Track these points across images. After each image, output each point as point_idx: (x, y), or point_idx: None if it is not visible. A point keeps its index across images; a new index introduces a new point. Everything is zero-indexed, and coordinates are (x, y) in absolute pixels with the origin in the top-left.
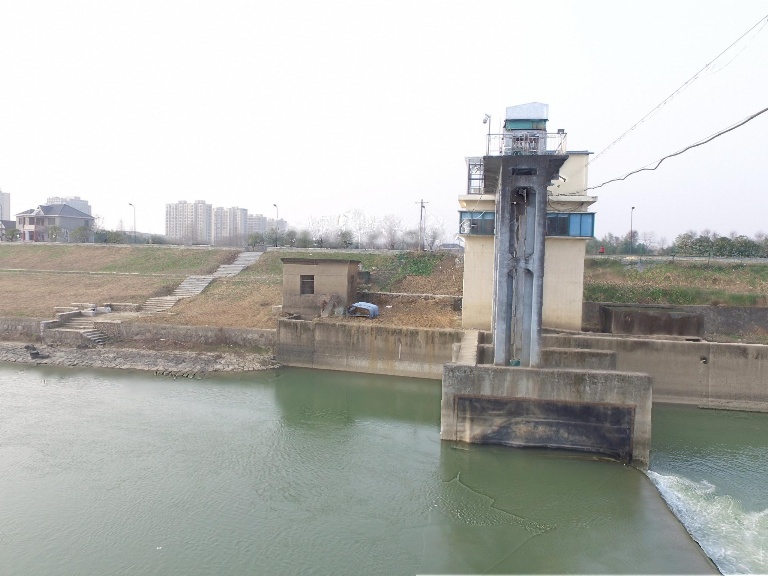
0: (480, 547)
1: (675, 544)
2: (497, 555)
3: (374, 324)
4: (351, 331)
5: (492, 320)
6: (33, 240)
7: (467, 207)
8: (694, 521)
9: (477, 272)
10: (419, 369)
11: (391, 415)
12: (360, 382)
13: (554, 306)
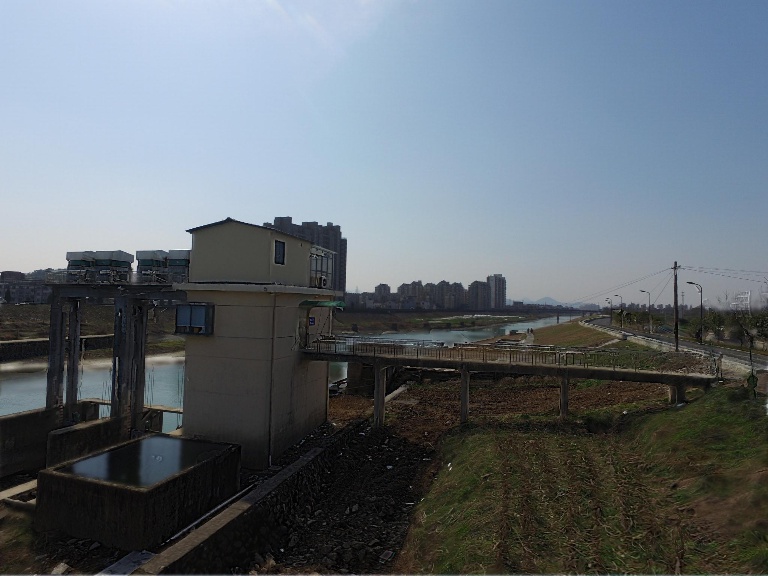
0: None
1: None
2: None
3: None
4: None
5: None
6: None
7: None
8: None
9: None
10: None
11: None
12: None
13: None
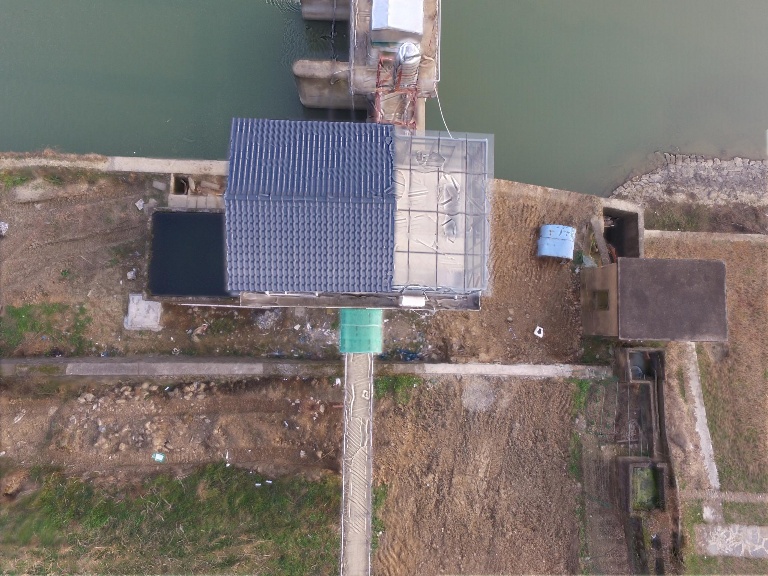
0: None
1: None
2: None
3: (527, 190)
4: None
5: None
6: None
7: None
8: None
9: None
10: None
11: None
12: None
13: None
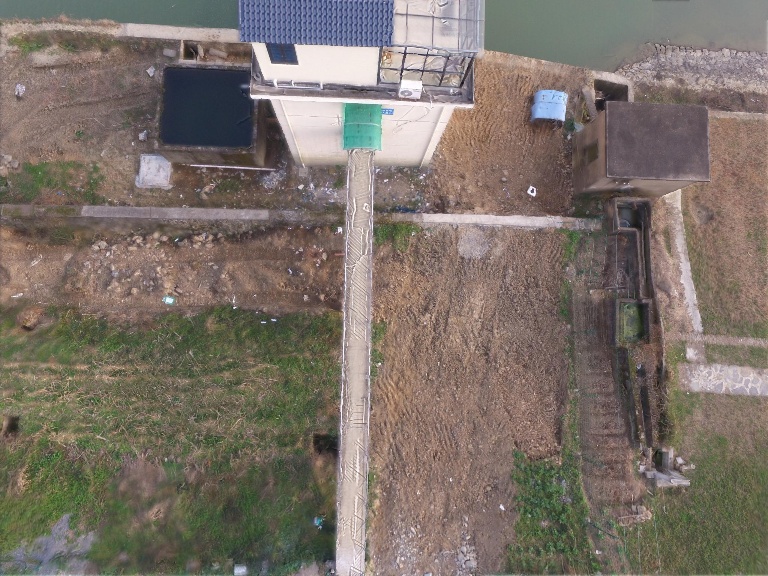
0: None
1: None
2: None
3: (522, 62)
4: None
5: None
6: None
7: None
8: None
9: None
10: None
11: None
12: None
13: None
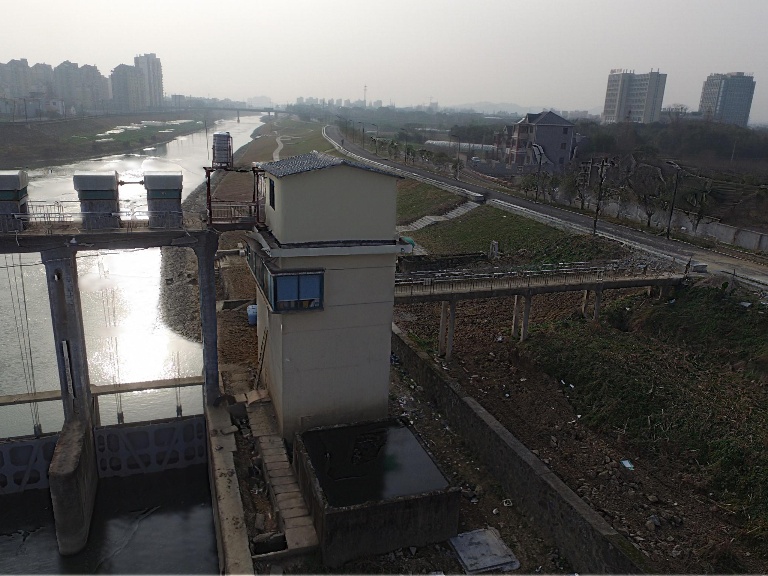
0: None
1: None
2: None
3: None
4: None
5: None
6: (516, 147)
7: None
8: None
9: None
10: None
11: None
12: None
13: (275, 388)
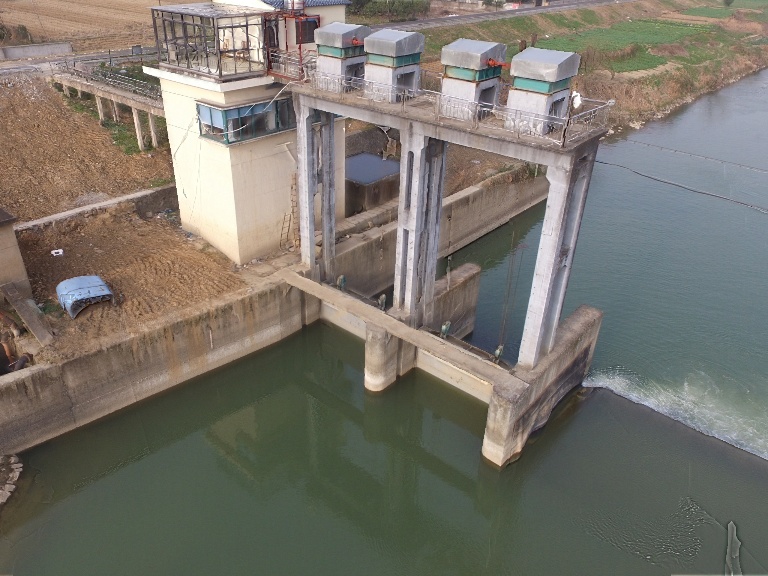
0: (744, 574)
1: (742, 460)
2: (759, 571)
3: (160, 321)
4: (132, 348)
5: (310, 255)
6: None
7: (226, 99)
8: (677, 417)
9: (248, 189)
10: (239, 348)
11: (212, 416)
12: (162, 404)
13: None
